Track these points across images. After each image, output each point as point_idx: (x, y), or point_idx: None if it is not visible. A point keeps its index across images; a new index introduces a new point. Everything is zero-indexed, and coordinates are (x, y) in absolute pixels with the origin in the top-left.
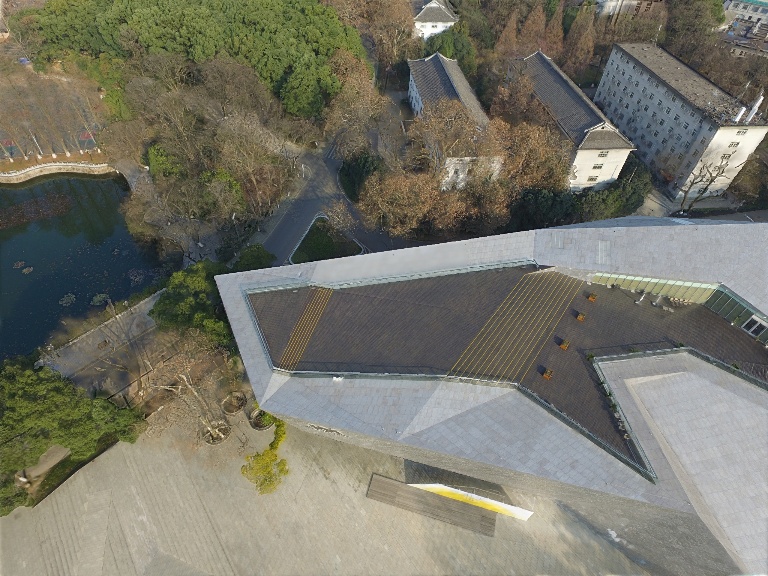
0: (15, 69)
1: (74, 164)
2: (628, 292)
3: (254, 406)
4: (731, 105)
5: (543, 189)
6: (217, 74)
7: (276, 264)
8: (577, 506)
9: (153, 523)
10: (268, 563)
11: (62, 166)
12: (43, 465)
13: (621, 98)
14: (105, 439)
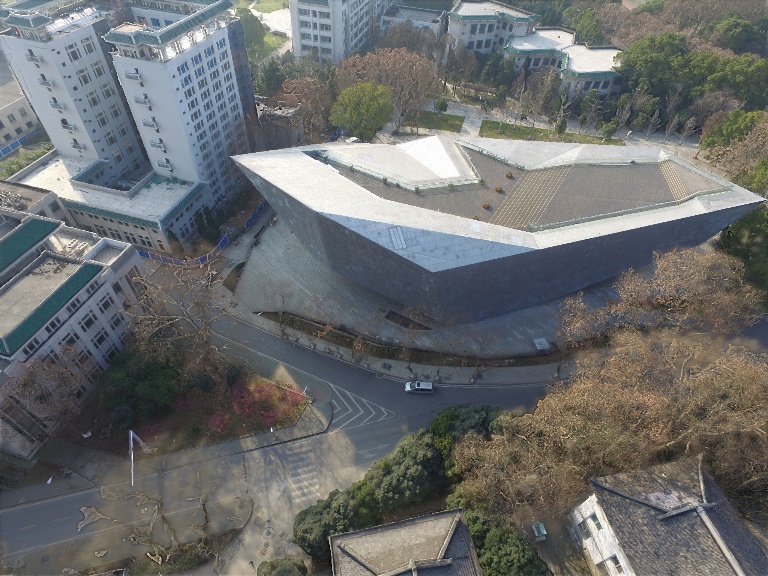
0: None
1: None
2: None
3: None
4: None
5: None
6: None
7: None
8: None
9: None
10: None
11: None
12: None
13: None
14: None
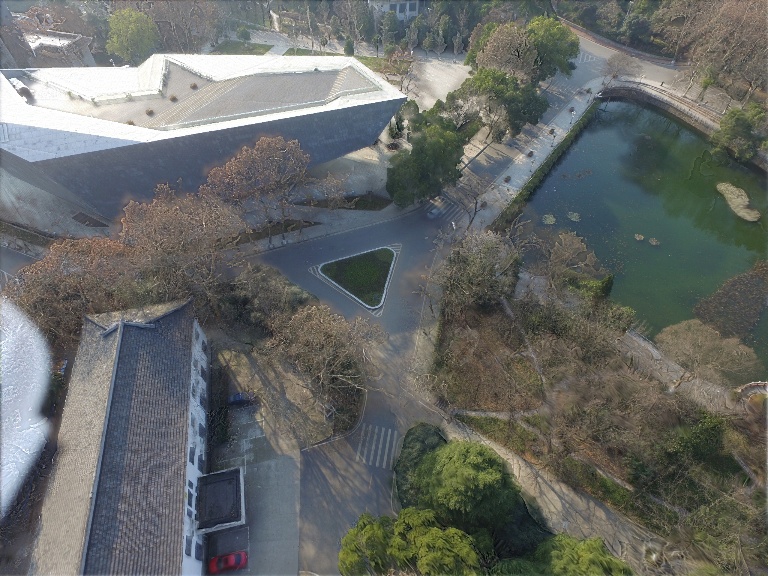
0: None
1: None
2: None
3: (379, 143)
4: None
5: None
6: None
7: (408, 249)
8: None
9: None
10: None
11: None
12: (485, 130)
13: None
14: None
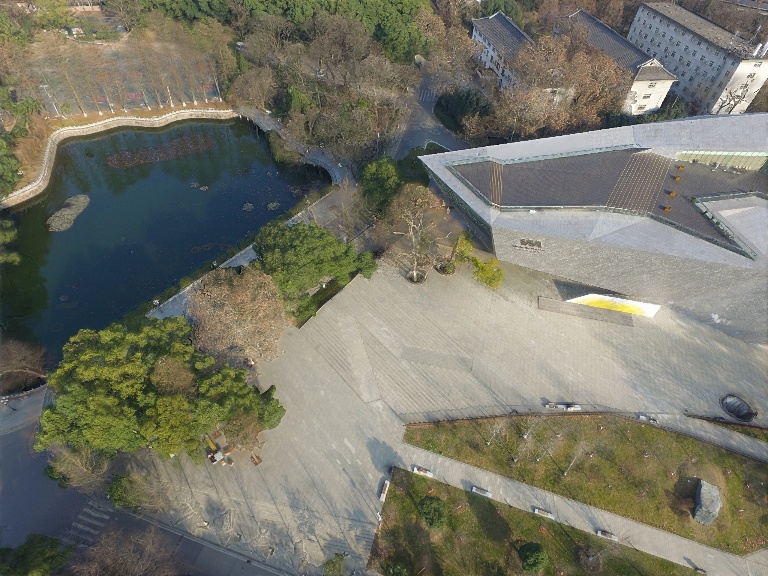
0: (169, 24)
1: (204, 110)
2: (705, 165)
3: None
4: (746, 45)
5: (613, 110)
6: (336, 27)
7: None
8: (688, 303)
9: (394, 331)
10: (487, 346)
11: (193, 112)
12: None
13: (648, 48)
14: (331, 288)
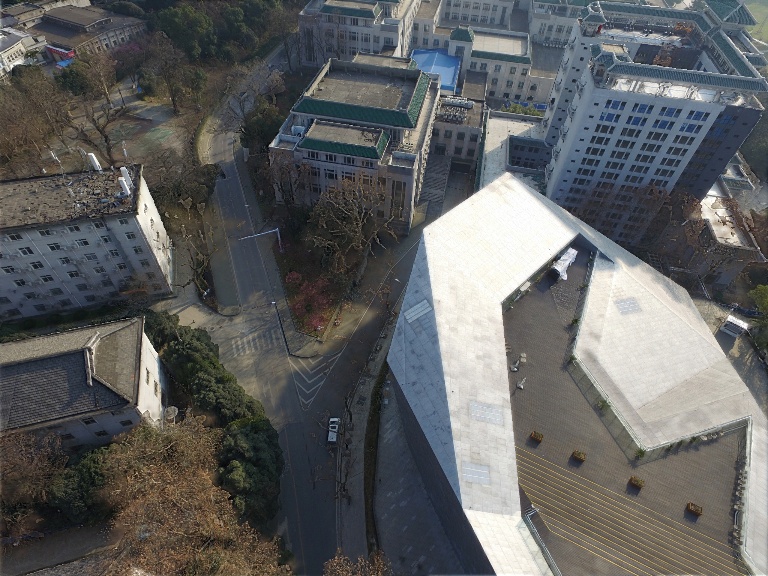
0: None
1: None
2: None
3: None
4: (74, 185)
5: (233, 478)
6: None
7: None
8: None
9: None
10: None
11: None
12: None
13: None
14: None
